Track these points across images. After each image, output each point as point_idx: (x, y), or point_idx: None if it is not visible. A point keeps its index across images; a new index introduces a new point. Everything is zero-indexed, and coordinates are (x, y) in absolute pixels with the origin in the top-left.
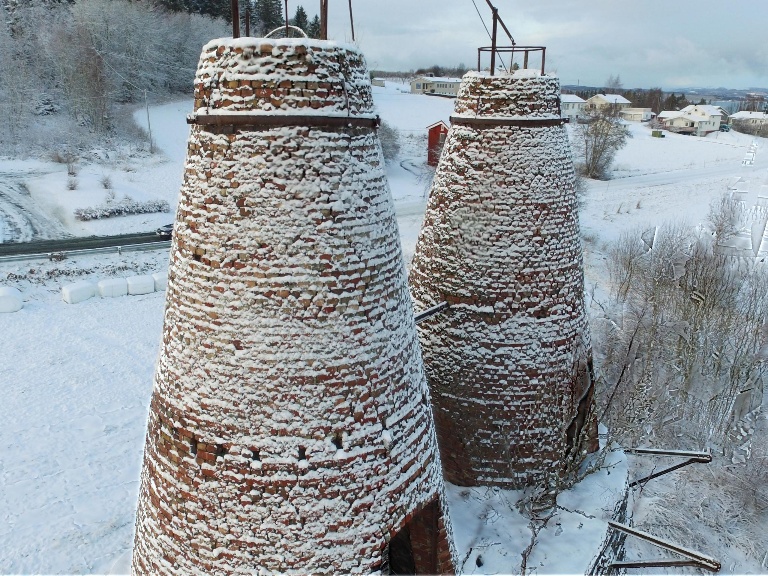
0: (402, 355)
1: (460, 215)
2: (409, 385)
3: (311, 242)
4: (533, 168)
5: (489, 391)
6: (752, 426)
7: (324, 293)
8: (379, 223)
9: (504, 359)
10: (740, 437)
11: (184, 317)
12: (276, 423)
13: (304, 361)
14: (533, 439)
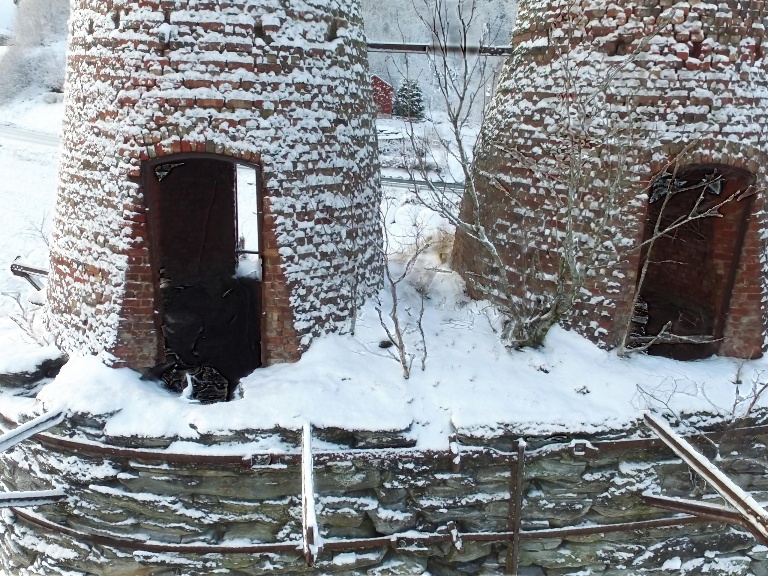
0: None
1: None
2: None
3: None
4: None
5: None
6: None
7: None
8: None
9: (545, 115)
10: None
11: None
12: None
13: None
14: None
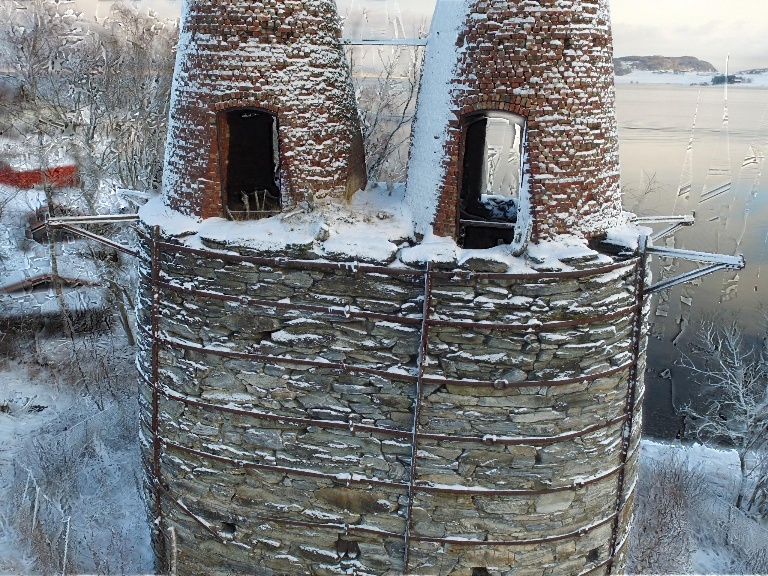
0: None
1: None
2: None
3: None
4: None
5: None
6: None
7: None
8: None
9: None
10: None
11: None
12: None
13: None
14: None
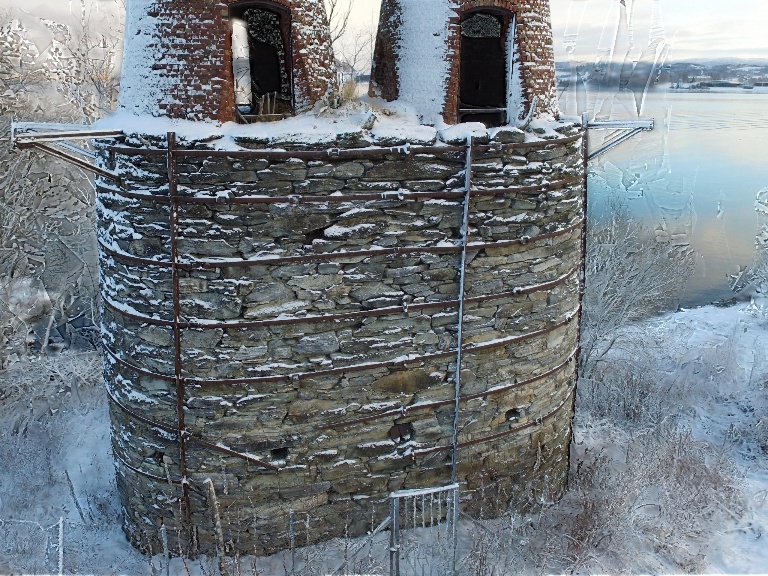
0: None
1: None
2: None
3: None
4: None
5: None
6: None
7: None
8: None
9: None
10: None
11: None
12: None
13: None
14: None
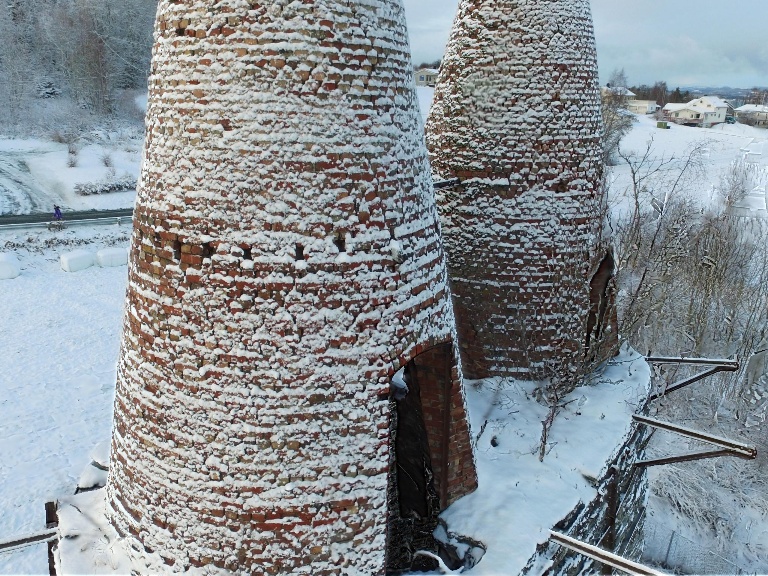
0: (412, 163)
1: (472, 81)
2: (420, 200)
3: (310, 4)
4: (552, 25)
5: (504, 271)
6: (766, 389)
7: (324, 66)
8: (387, 3)
9: (520, 236)
10: (754, 401)
11: (166, 105)
12: (270, 215)
13: (302, 144)
14: (551, 325)
